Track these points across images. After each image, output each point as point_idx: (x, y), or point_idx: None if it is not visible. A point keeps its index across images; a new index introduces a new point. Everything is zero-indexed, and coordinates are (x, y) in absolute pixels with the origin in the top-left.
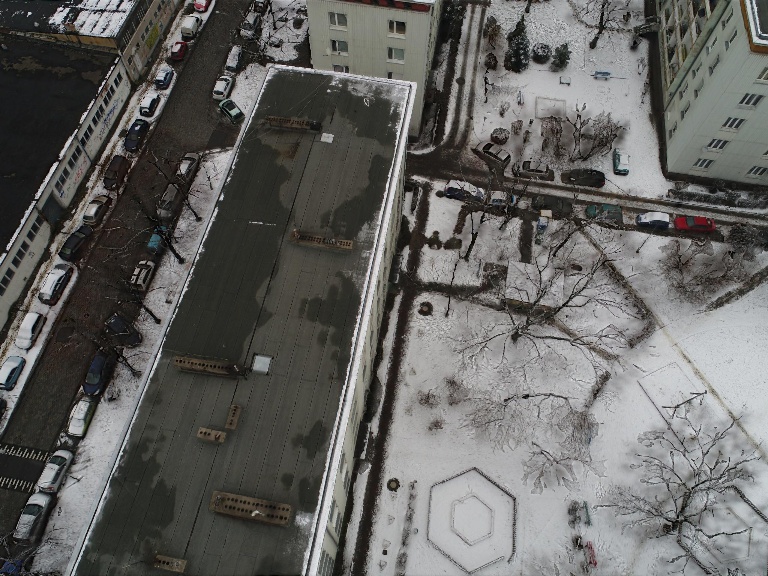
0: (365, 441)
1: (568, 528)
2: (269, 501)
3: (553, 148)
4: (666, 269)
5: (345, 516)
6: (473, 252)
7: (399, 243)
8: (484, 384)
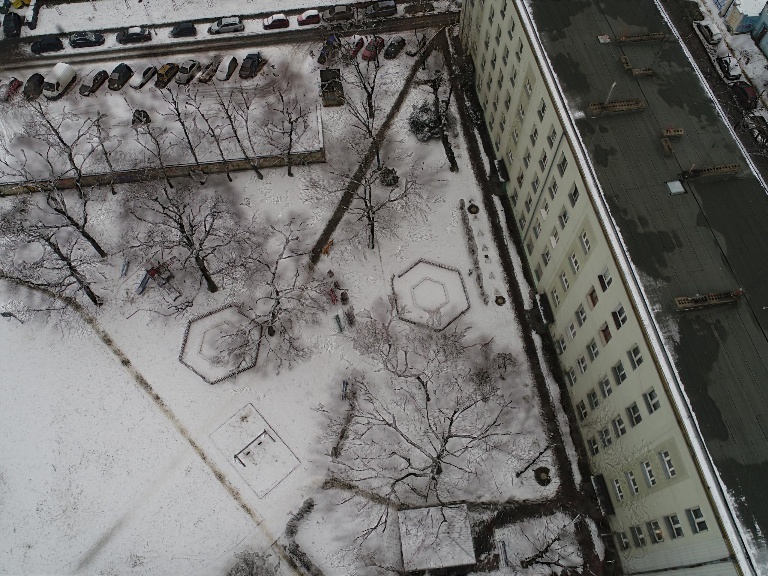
0: (542, 308)
1: None
2: (608, 111)
3: None
4: None
5: (527, 269)
6: None
7: None
8: None
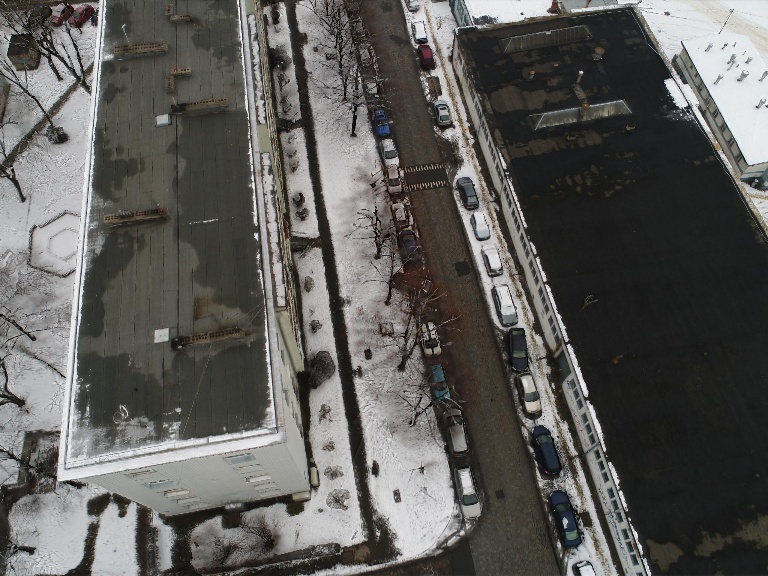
0: None
1: None
2: (129, 52)
3: None
4: None
5: None
6: (71, 497)
7: None
8: (57, 348)
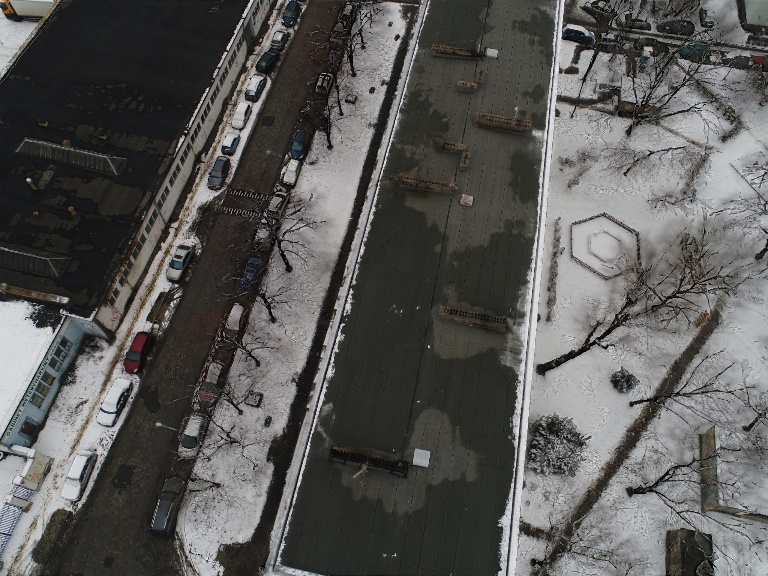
0: None
1: (681, 253)
2: None
3: (650, 4)
4: (753, 79)
5: None
6: (589, 75)
7: None
8: None
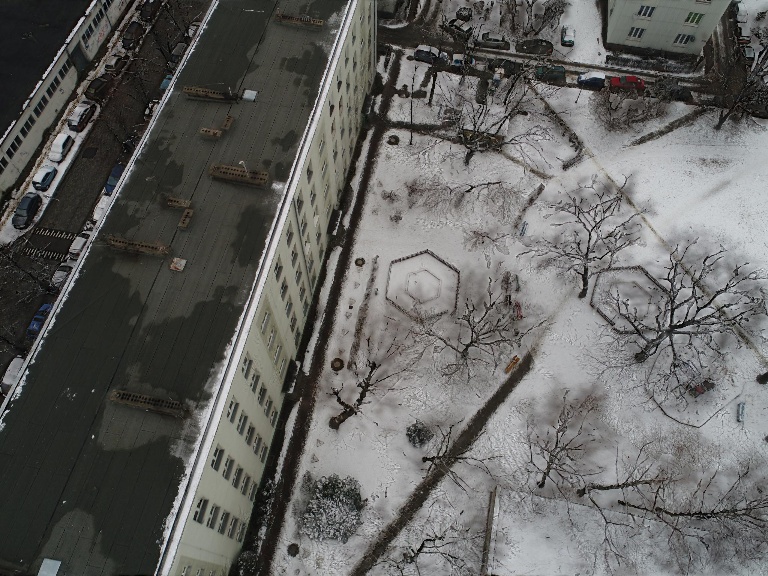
0: (337, 223)
1: (501, 292)
2: None
3: (509, 22)
4: (595, 104)
5: (319, 282)
6: (436, 100)
7: (373, 92)
8: None
